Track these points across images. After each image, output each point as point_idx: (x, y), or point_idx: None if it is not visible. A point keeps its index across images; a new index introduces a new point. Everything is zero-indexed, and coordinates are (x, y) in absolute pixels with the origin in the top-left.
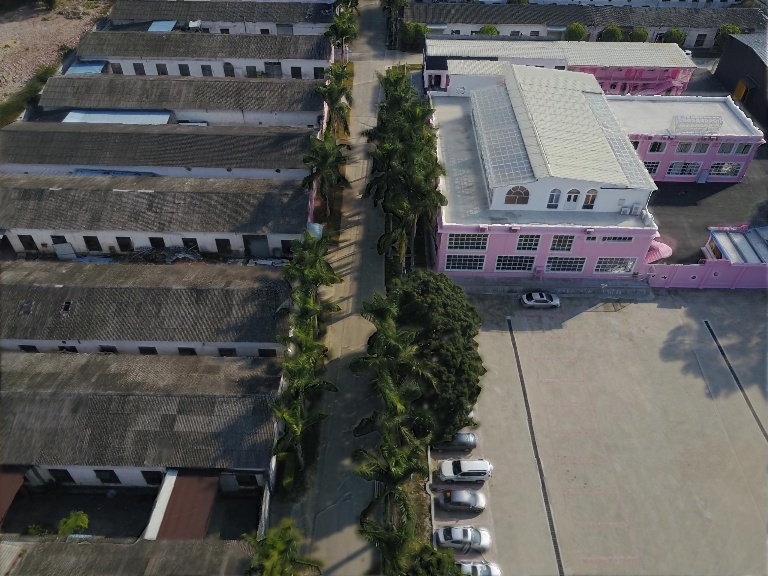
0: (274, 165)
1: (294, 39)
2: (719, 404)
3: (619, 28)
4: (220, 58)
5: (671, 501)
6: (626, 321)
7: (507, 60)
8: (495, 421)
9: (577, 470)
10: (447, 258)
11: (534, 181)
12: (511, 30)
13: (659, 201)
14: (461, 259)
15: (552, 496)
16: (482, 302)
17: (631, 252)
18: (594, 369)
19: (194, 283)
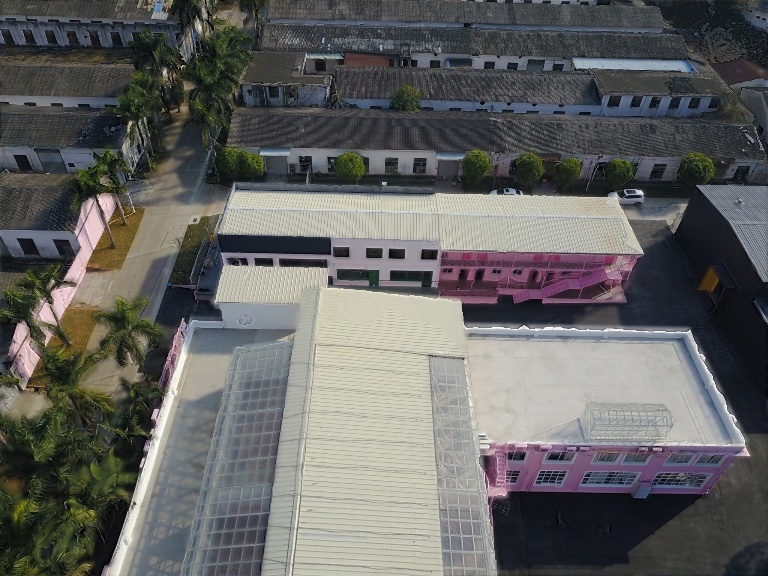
0: None
1: (26, 192)
2: None
3: (540, 157)
4: None
5: None
6: None
7: (345, 241)
8: None
9: None
10: None
11: None
12: (385, 156)
13: (563, 551)
14: None
15: None
16: None
17: None
18: None
19: None
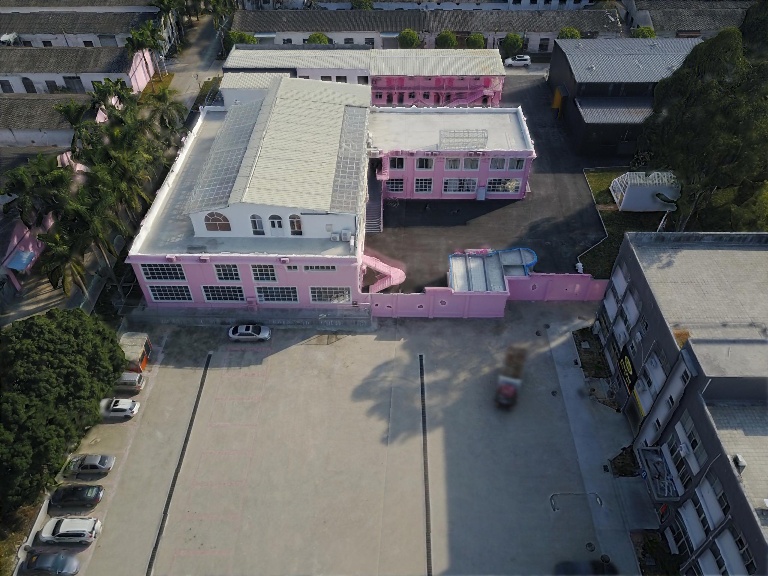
0: None
1: (96, 52)
2: (391, 450)
3: (454, 34)
4: (16, 73)
5: (285, 565)
6: (333, 356)
7: (306, 71)
8: (139, 471)
9: (200, 528)
10: (151, 289)
11: (225, 207)
12: (344, 37)
13: (427, 221)
14: (165, 290)
15: (160, 558)
16: (190, 335)
17: (341, 281)
18: (273, 411)
19: None
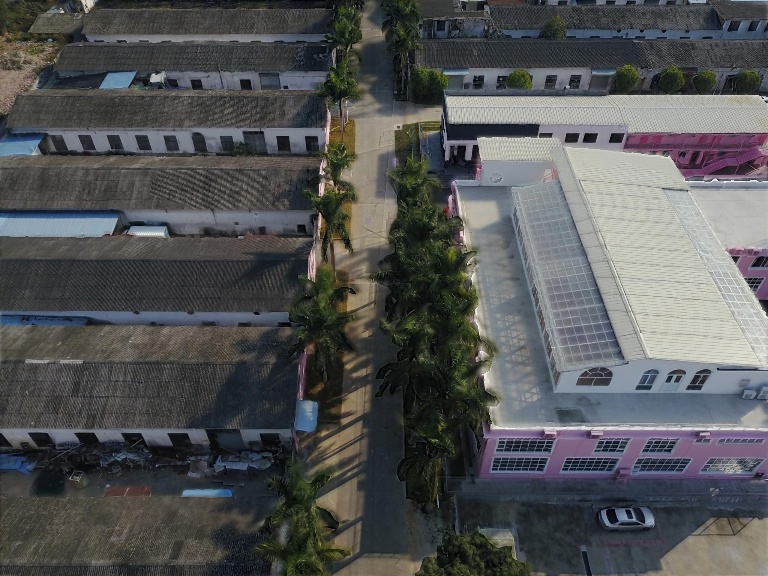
0: (251, 306)
1: (280, 100)
2: None
3: (681, 70)
4: (187, 128)
5: None
6: (752, 554)
7: (551, 127)
8: None
9: None
10: (494, 460)
11: (622, 364)
12: (547, 74)
13: None
14: (514, 461)
15: None
16: (544, 519)
17: (757, 453)
18: None
19: (126, 549)
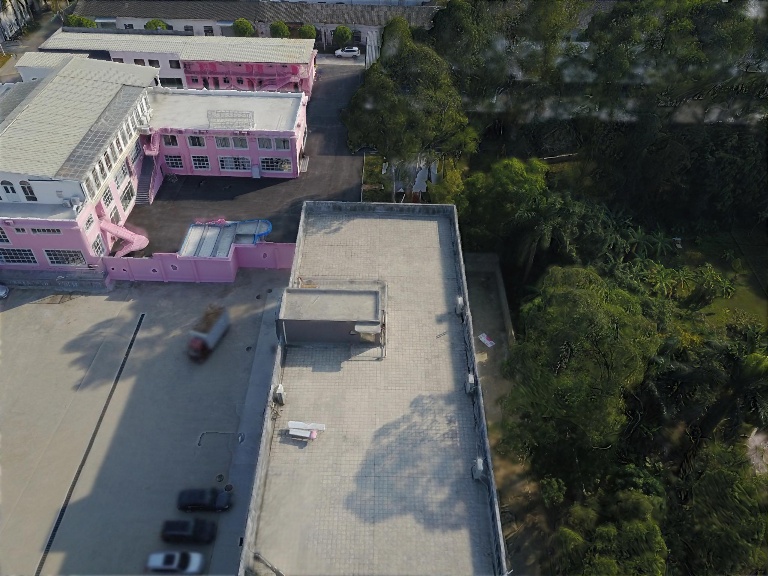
0: None
1: None
2: (78, 396)
3: (287, 24)
4: None
5: None
6: (60, 313)
7: (119, 54)
8: None
9: None
10: None
11: None
12: (184, 25)
13: (198, 195)
14: None
15: None
16: None
17: (71, 244)
18: None
19: None
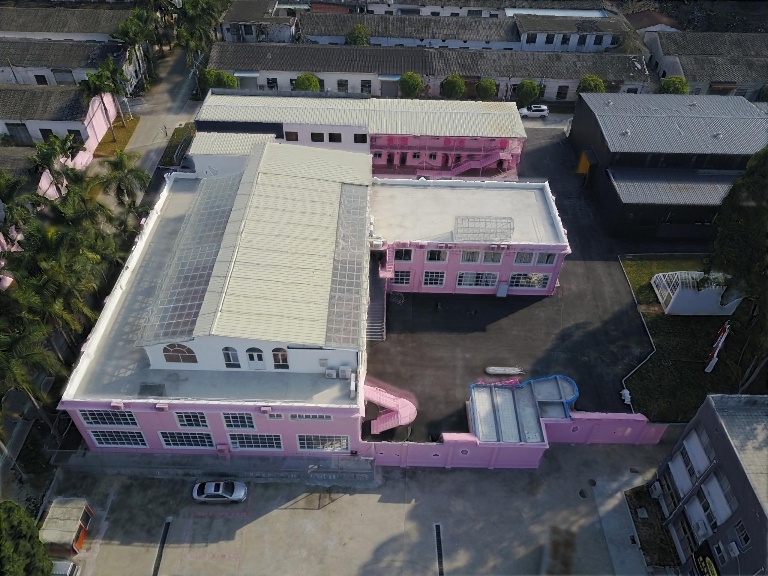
0: None
1: (46, 94)
2: None
3: (463, 78)
4: None
5: None
6: (326, 527)
7: (294, 126)
8: None
9: None
10: (93, 433)
11: (189, 340)
12: (337, 78)
13: (438, 325)
14: (112, 435)
15: None
16: (143, 492)
17: (338, 430)
18: None
19: None
